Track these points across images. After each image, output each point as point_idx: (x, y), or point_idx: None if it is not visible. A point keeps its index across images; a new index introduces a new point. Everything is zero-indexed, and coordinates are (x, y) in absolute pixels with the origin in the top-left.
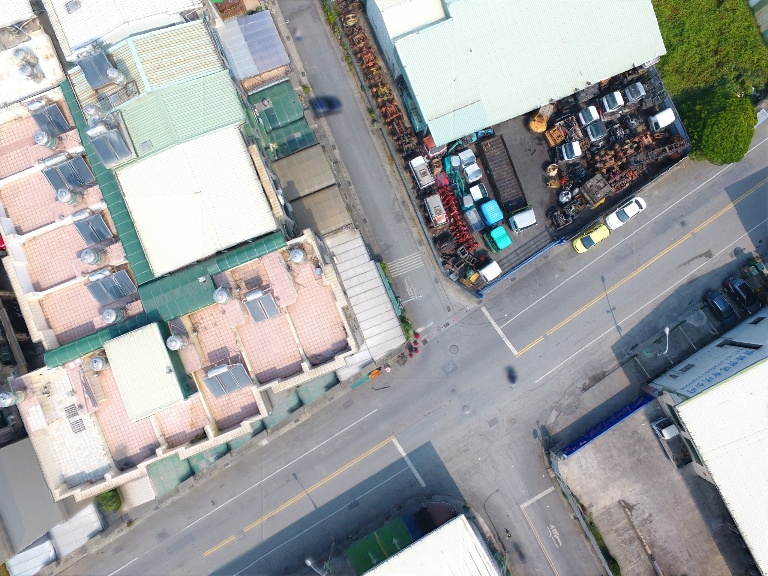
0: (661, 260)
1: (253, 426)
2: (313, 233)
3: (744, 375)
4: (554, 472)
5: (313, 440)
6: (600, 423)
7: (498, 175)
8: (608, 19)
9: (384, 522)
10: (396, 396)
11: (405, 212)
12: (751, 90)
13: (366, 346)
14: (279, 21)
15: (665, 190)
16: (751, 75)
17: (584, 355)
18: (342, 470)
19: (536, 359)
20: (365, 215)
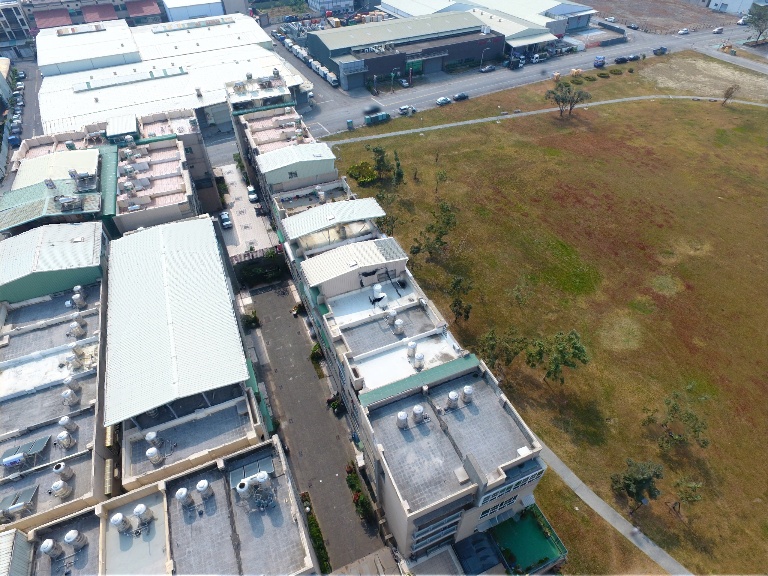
0: None
1: None
2: None
3: None
4: (4, 175)
5: None
6: None
7: None
8: None
9: None
10: None
11: None
12: None
13: None
14: None
15: None
16: None
17: None
18: None
19: None
20: None
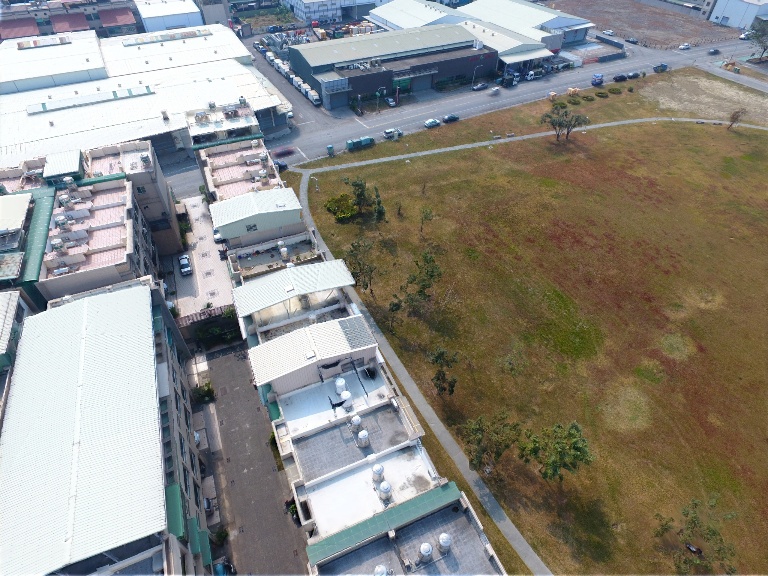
0: None
1: None
2: None
3: None
4: None
5: None
6: None
7: None
8: None
9: None
10: None
11: None
12: None
13: None
14: None
15: None
16: None
17: None
18: None
19: None
20: None
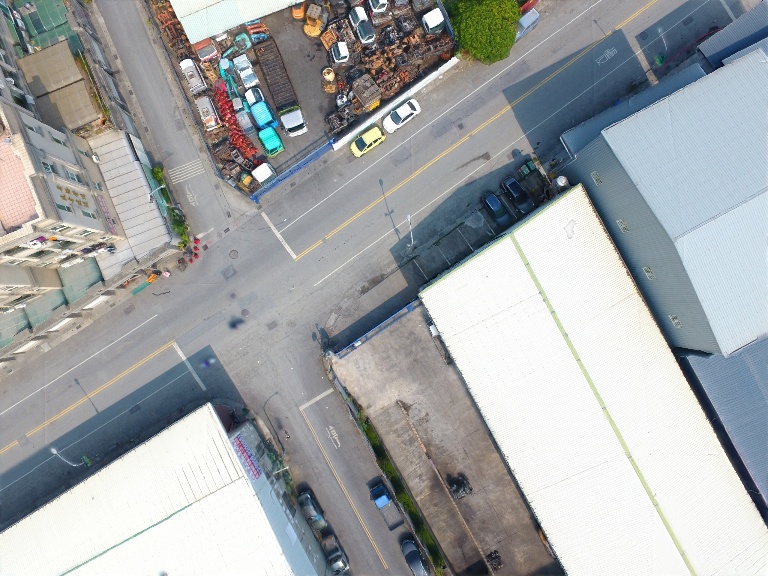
0: (439, 163)
1: (18, 325)
2: (12, 107)
3: (479, 258)
4: None
5: (95, 346)
6: (377, 324)
7: (272, 79)
8: None
9: (165, 425)
10: (176, 301)
11: (186, 120)
12: None
13: (129, 245)
14: None
15: (443, 94)
16: None
17: (363, 258)
18: (123, 375)
19: (315, 263)
20: (146, 123)
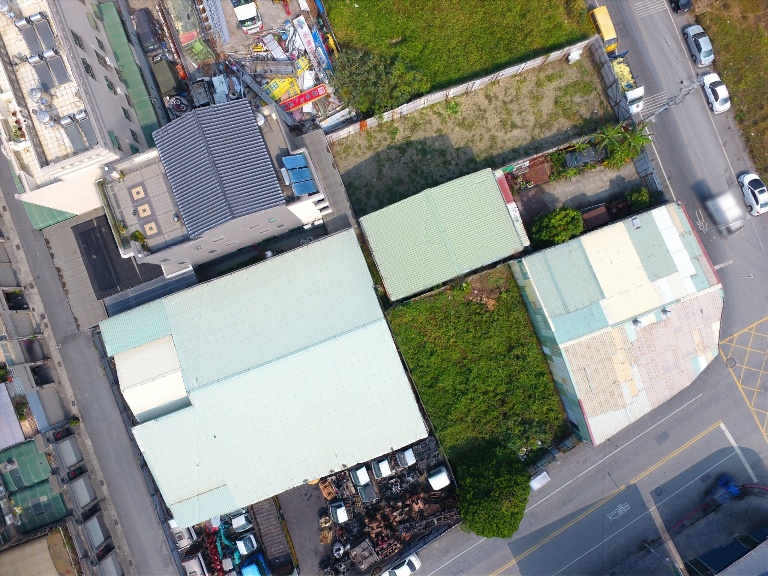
0: None
1: None
2: None
3: None
4: None
5: None
6: None
7: (265, 529)
8: (364, 403)
9: None
10: None
11: None
12: (536, 446)
13: None
14: (51, 345)
15: (445, 542)
16: (536, 431)
17: None
18: None
19: None
20: (131, 557)
